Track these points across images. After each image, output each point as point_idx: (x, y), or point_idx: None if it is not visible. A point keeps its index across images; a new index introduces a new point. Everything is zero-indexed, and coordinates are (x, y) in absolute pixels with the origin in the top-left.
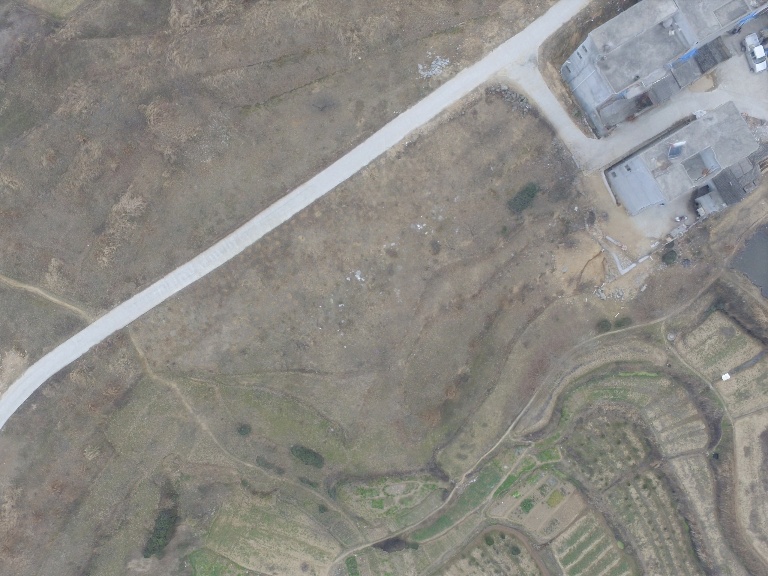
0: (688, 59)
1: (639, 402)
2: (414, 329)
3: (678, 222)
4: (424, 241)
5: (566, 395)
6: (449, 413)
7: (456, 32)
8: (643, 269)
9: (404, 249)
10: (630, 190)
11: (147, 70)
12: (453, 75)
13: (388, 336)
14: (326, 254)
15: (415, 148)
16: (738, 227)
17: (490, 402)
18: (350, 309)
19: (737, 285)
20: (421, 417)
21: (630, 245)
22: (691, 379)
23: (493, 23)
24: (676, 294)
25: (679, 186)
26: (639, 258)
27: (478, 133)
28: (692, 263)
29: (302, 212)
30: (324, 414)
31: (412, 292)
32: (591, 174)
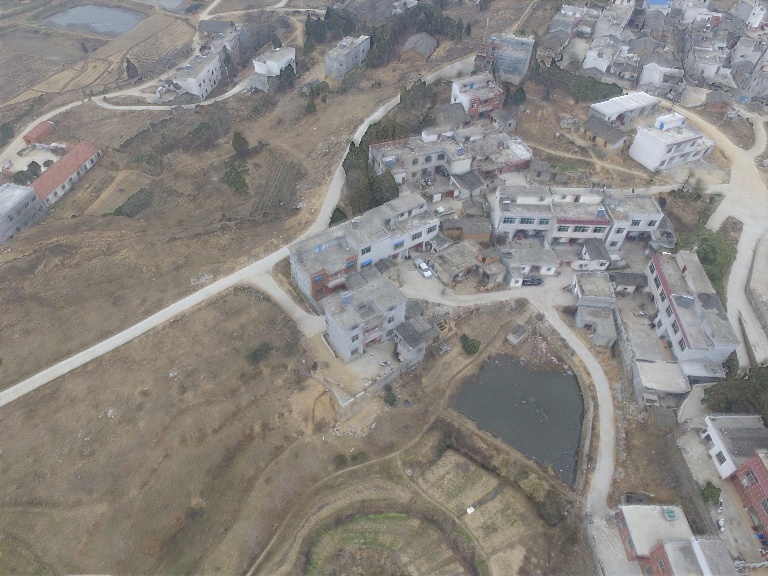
0: (372, 268)
1: (391, 544)
2: (151, 460)
3: (384, 366)
4: (173, 385)
5: (312, 538)
6: (177, 553)
7: (220, 263)
8: (371, 410)
9: (155, 392)
10: (337, 342)
11: (4, 295)
12: (213, 282)
13: (123, 465)
14: (87, 398)
15: (178, 324)
16: (444, 375)
17: (226, 543)
18: (94, 442)
19: (453, 419)
20: (144, 556)
21: (347, 384)
22: (435, 513)
23: (245, 257)
24: (403, 429)
25: (352, 323)
26: (356, 394)
27: (226, 313)
28: (412, 404)
29: (77, 369)
30: (39, 557)
31: (154, 426)
32: (313, 337)
